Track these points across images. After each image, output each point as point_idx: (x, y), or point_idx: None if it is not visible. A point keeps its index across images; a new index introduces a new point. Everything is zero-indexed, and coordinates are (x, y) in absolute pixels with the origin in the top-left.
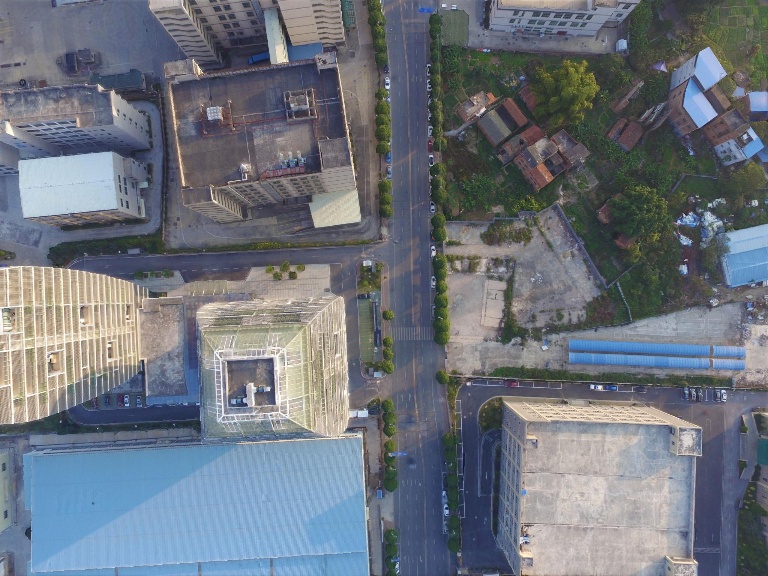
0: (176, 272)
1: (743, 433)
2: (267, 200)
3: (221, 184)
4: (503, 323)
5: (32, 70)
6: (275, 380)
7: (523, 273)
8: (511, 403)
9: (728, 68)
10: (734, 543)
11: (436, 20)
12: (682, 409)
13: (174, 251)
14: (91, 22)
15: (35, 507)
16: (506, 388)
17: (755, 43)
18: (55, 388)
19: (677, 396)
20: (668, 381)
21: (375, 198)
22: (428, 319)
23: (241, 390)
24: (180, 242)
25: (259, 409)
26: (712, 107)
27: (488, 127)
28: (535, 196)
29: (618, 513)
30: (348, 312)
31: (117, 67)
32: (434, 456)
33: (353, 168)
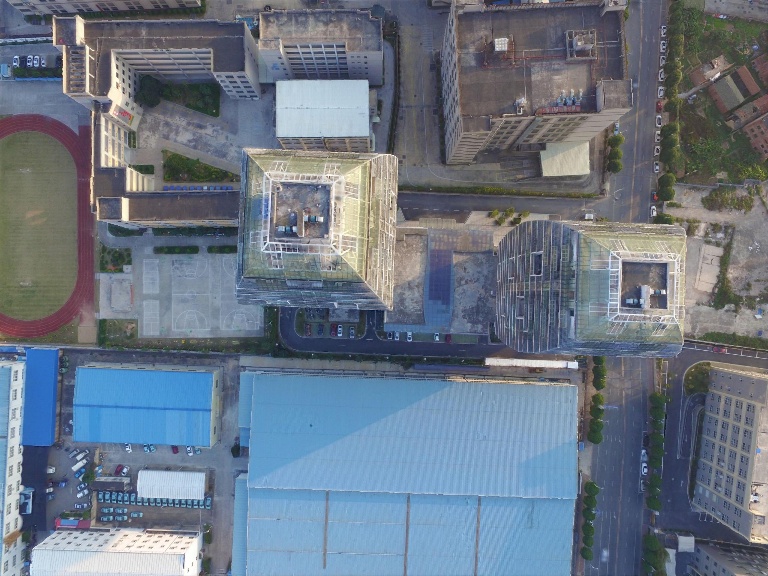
0: None
1: None
2: (502, 144)
3: None
4: (717, 289)
5: None
6: (668, 285)
7: (741, 241)
8: (722, 368)
9: None
10: None
11: None
12: None
13: (401, 187)
14: None
15: (254, 424)
16: (714, 353)
17: None
18: None
19: None
20: None
21: (599, 154)
22: None
23: (633, 292)
24: (404, 180)
25: None
26: None
27: (723, 92)
28: (760, 165)
29: None
30: None
31: (356, 2)
32: (636, 414)
33: None
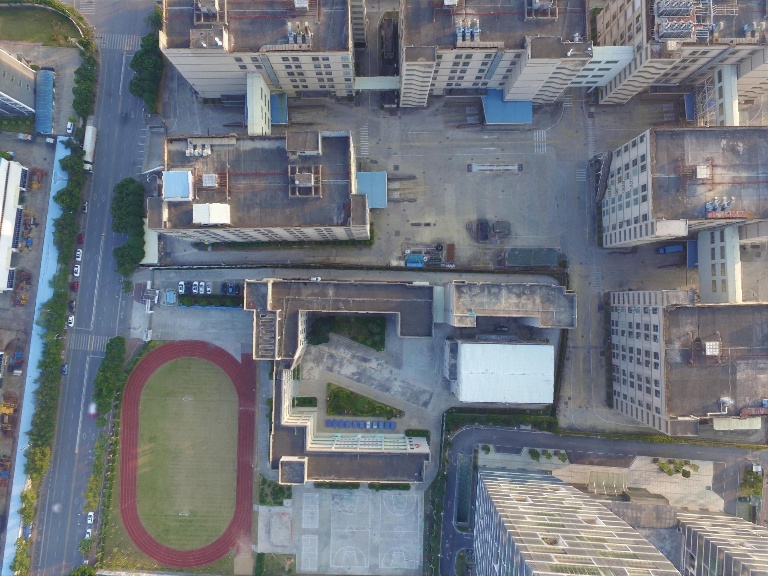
0: (562, 451)
1: None
2: None
3: (699, 414)
4: None
5: (441, 232)
6: None
7: None
8: None
9: None
10: None
11: None
12: None
13: (569, 434)
14: (504, 191)
15: None
16: None
17: None
18: None
19: None
20: None
21: None
22: None
23: None
24: (569, 422)
25: None
26: None
27: None
28: None
29: None
30: (727, 513)
31: (525, 239)
32: None
33: None
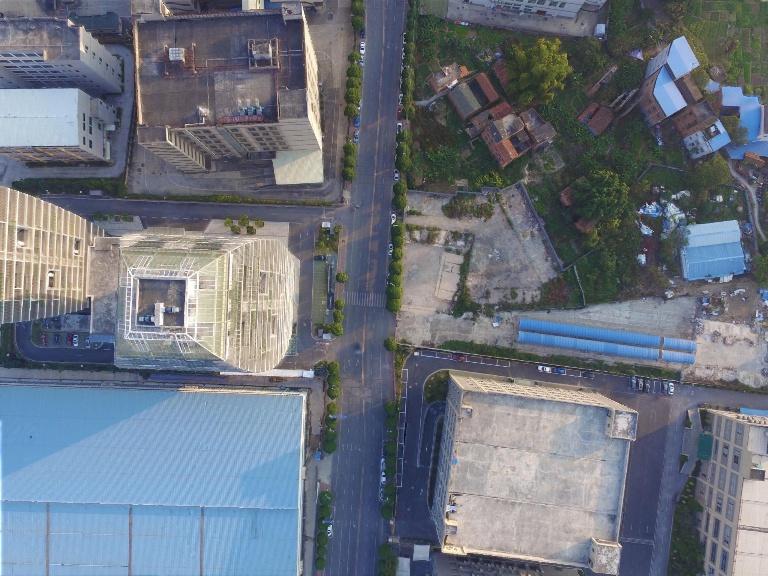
0: (136, 217)
1: (687, 427)
2: (231, 152)
3: (178, 126)
4: (457, 297)
5: (11, 5)
6: (185, 302)
7: (481, 249)
8: (457, 376)
9: (703, 60)
10: (668, 536)
11: None
12: (628, 398)
13: (135, 196)
14: None
15: None
16: (454, 362)
17: (735, 40)
18: None
19: (624, 385)
20: (616, 369)
21: (340, 161)
22: (382, 286)
23: (151, 309)
24: (143, 188)
25: (169, 331)
26: (682, 97)
27: (458, 99)
28: (500, 173)
29: (548, 490)
30: (303, 272)
31: (96, 9)
32: (376, 423)
33: (317, 126)
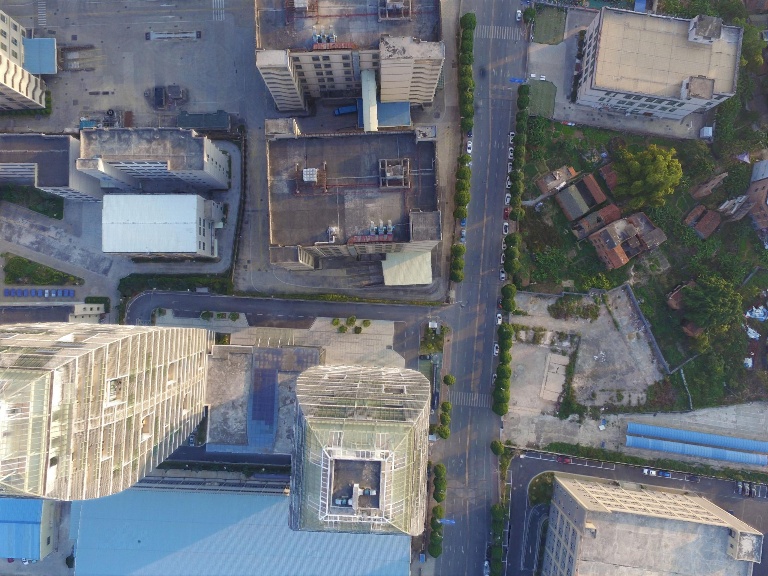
0: (241, 314)
1: None
2: (341, 254)
3: (308, 244)
4: (562, 398)
5: (119, 100)
6: (381, 483)
7: (587, 350)
8: (564, 480)
9: None
10: None
11: (525, 91)
12: (734, 503)
13: (243, 294)
14: (182, 58)
15: (81, 539)
16: (559, 463)
17: None
18: (144, 452)
19: (730, 489)
20: (723, 473)
21: (446, 260)
22: (487, 386)
23: (346, 489)
24: (248, 285)
25: None
26: None
27: (567, 202)
28: (606, 274)
29: None
30: None
31: (203, 105)
32: (480, 524)
33: None
